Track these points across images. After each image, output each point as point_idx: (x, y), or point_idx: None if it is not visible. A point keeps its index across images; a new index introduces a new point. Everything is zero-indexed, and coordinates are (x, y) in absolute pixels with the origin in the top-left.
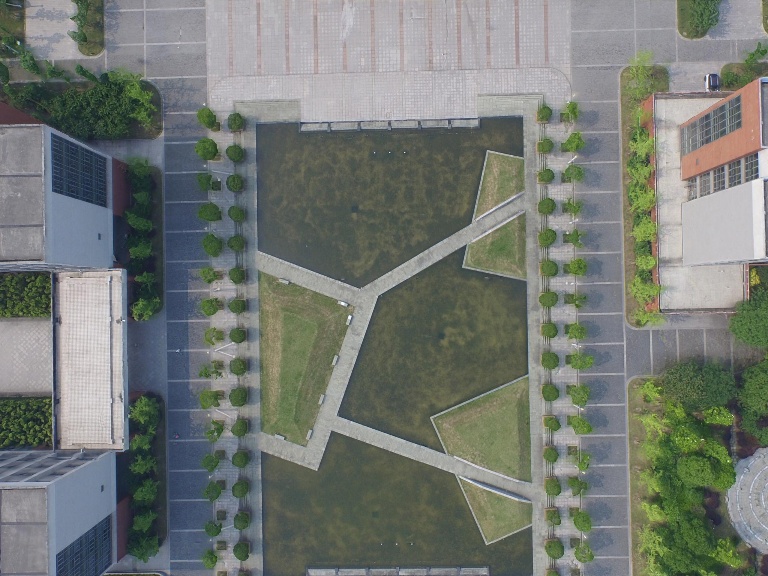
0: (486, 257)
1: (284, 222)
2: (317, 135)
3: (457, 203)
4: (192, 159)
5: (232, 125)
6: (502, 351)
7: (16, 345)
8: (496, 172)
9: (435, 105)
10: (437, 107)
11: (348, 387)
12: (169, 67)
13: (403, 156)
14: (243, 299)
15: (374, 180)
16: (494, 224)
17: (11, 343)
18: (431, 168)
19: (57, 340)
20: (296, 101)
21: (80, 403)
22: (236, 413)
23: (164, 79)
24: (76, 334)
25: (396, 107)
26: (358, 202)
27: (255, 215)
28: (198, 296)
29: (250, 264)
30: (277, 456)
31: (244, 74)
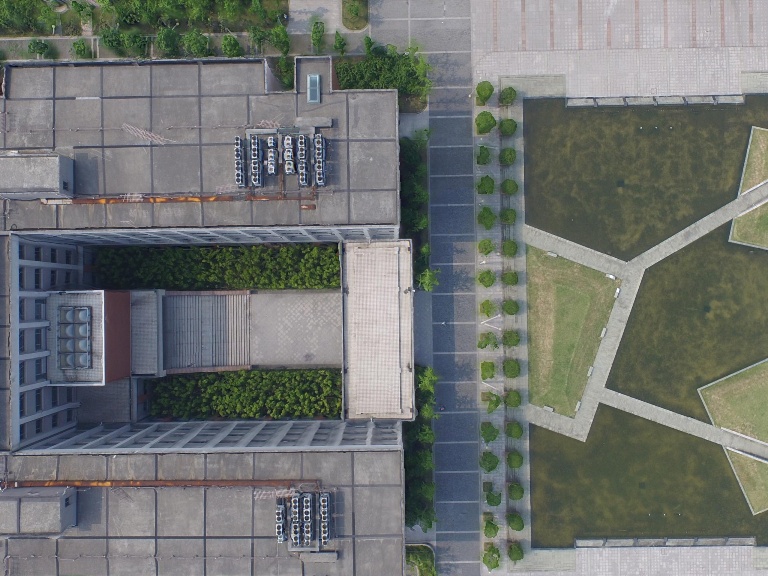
0: (754, 231)
1: (550, 196)
2: (583, 110)
3: (722, 178)
4: (457, 133)
5: (506, 99)
6: (767, 324)
7: (280, 317)
8: (763, 147)
9: (699, 81)
10: (701, 83)
11: (615, 359)
12: (433, 42)
13: (668, 131)
14: (512, 272)
15: (639, 155)
16: (760, 199)
17: (275, 315)
18: (696, 143)
19: (344, 310)
20: (561, 76)
21: (369, 373)
22: (502, 385)
23: (428, 54)
24: (365, 304)
25: (661, 83)
26: (624, 177)
27: (522, 189)
28: (463, 269)
29: (518, 237)
30: (545, 428)
31: (509, 49)
